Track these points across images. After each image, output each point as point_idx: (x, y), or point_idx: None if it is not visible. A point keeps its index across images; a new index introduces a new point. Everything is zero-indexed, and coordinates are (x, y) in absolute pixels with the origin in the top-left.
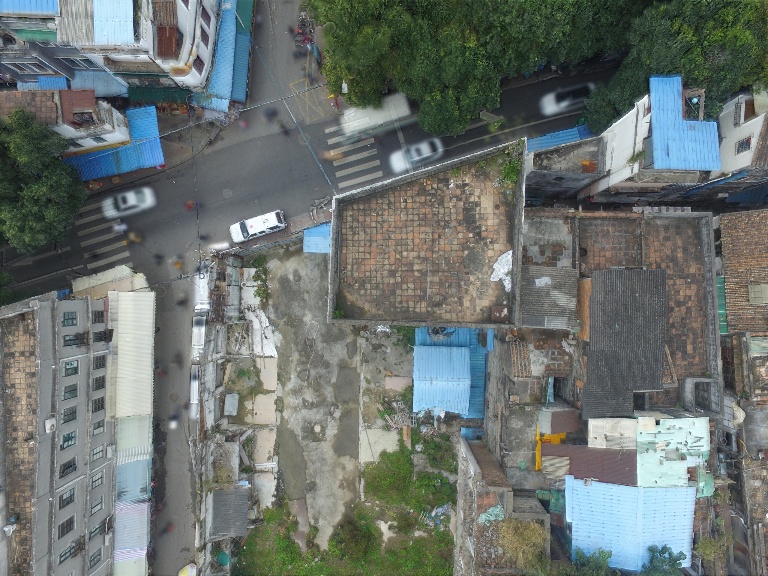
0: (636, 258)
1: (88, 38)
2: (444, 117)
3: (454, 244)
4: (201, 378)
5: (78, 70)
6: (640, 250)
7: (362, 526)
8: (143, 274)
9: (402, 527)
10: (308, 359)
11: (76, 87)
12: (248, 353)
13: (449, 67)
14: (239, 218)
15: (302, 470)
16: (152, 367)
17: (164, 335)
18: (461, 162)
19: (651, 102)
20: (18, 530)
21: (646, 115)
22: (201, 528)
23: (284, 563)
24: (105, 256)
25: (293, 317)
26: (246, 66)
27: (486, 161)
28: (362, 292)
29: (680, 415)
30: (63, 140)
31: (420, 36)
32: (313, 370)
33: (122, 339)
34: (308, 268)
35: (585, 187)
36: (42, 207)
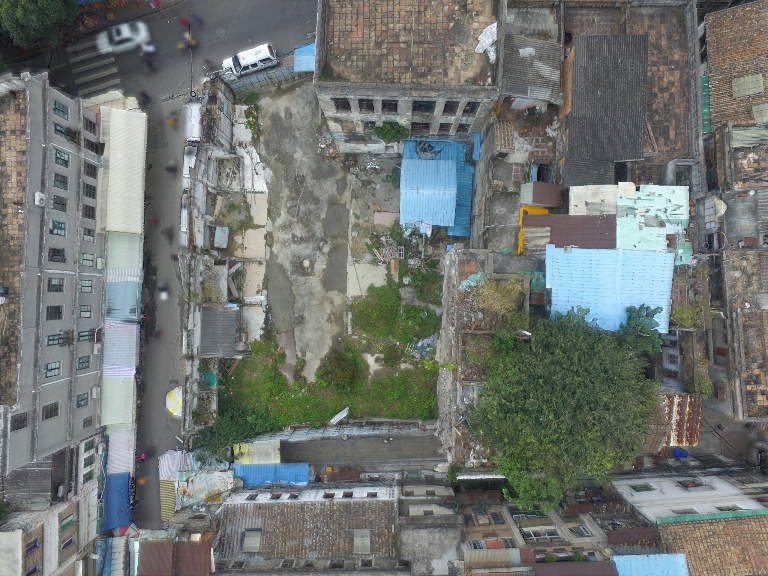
0: None
1: None
2: None
3: (440, 17)
4: (191, 190)
5: None
6: None
7: (349, 358)
8: (135, 98)
9: (388, 358)
10: (298, 195)
11: None
12: (239, 188)
13: None
14: None
15: (290, 304)
16: (143, 188)
17: (156, 172)
18: None
19: None
20: (7, 304)
21: None
22: (189, 337)
23: (271, 394)
24: (99, 94)
25: (284, 154)
26: None
27: None
28: (348, 64)
29: None
30: None
31: None
32: (303, 206)
33: (113, 155)
34: (299, 106)
35: None
36: None
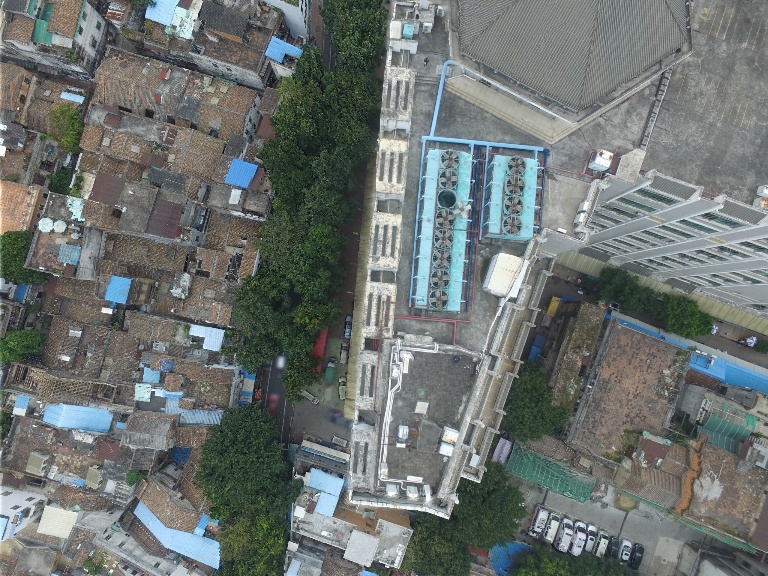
0: None
1: None
2: (325, 5)
3: None
4: None
5: None
6: None
7: None
8: None
9: None
10: None
11: None
12: None
13: (337, 3)
14: None
15: None
16: None
17: None
18: None
19: (295, 47)
20: None
21: None
22: None
23: None
24: None
25: None
26: None
27: None
28: None
29: None
30: None
31: None
32: None
33: None
34: None
35: None
36: None
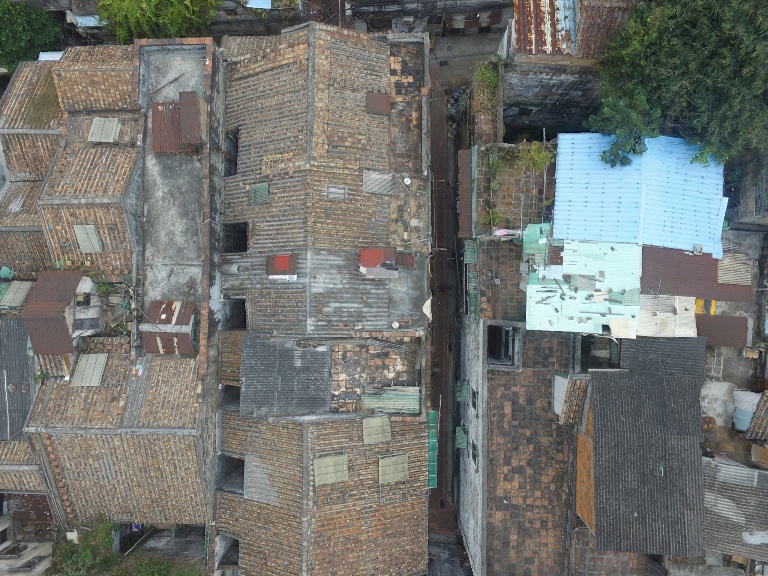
0: None
1: None
2: None
3: None
4: None
5: None
6: None
7: None
8: None
9: None
10: None
11: None
12: None
13: None
14: None
15: None
16: None
17: None
18: None
19: None
20: None
21: None
22: None
23: None
24: None
25: None
26: None
27: None
28: None
29: None
30: None
31: None
32: None
33: None
34: None
35: None
36: None
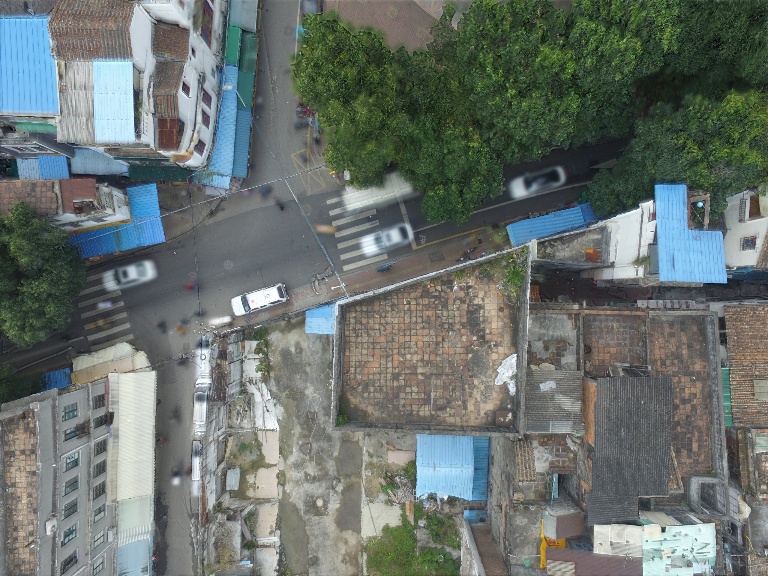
0: (641, 355)
1: (88, 136)
2: (447, 209)
3: (458, 347)
4: (203, 462)
5: (78, 148)
6: (645, 348)
7: None
8: (144, 352)
9: None
10: (310, 432)
11: (76, 165)
12: (250, 426)
13: (452, 164)
14: (240, 289)
15: (304, 544)
16: (153, 446)
17: (165, 407)
18: (465, 268)
19: (656, 211)
20: None
21: (651, 220)
22: None
23: None
24: (105, 327)
25: (295, 390)
26: (247, 141)
27: (490, 263)
28: (365, 395)
29: (686, 518)
30: (63, 233)
31: (423, 133)
32: (315, 443)
33: (123, 421)
34: (310, 340)
35: (589, 269)
36: (42, 301)
